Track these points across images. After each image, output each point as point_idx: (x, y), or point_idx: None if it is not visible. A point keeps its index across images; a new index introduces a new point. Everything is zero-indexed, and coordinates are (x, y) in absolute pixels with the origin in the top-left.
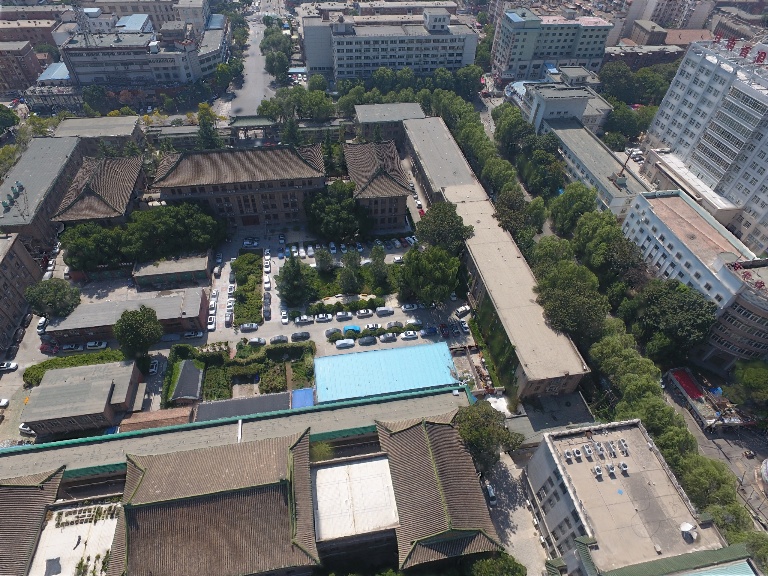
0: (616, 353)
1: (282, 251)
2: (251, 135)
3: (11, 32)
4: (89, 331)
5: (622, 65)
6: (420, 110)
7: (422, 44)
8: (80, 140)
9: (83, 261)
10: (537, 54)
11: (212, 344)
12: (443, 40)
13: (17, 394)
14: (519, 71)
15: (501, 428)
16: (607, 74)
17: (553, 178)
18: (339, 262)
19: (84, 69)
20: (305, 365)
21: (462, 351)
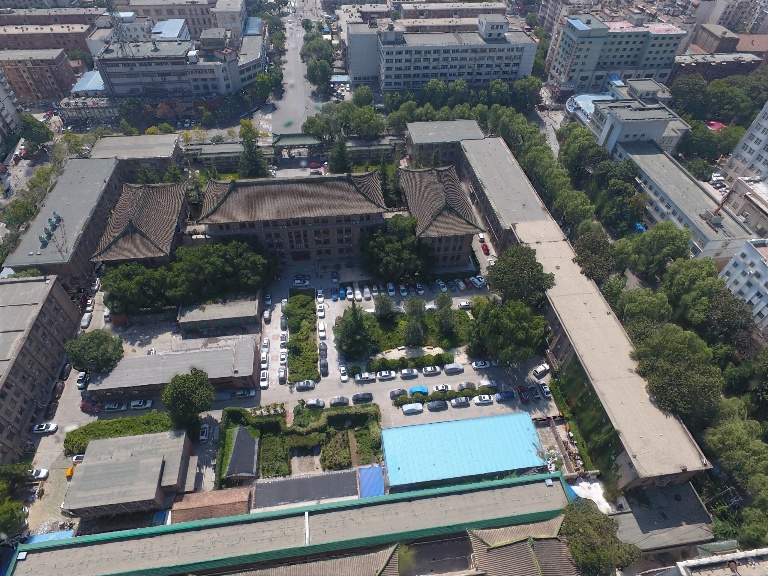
0: (742, 445)
1: (336, 292)
2: (295, 153)
3: (44, 38)
4: (133, 389)
5: (699, 79)
6: (478, 129)
7: (477, 54)
8: (118, 162)
9: (125, 305)
10: (599, 64)
11: (267, 407)
12: (500, 49)
13: (57, 462)
14: (580, 82)
15: (621, 548)
16: (681, 88)
17: (632, 211)
18: (399, 306)
19: (120, 80)
20: (371, 436)
21: (545, 421)
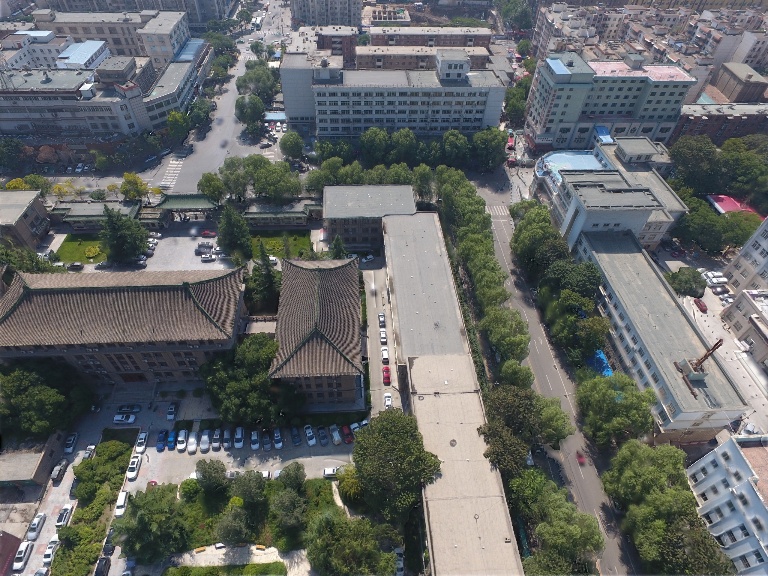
0: None
1: (164, 438)
2: (190, 216)
3: None
4: None
5: (705, 142)
6: (411, 199)
7: (430, 98)
8: None
9: None
10: (586, 112)
11: None
12: (458, 93)
13: None
14: (559, 135)
15: None
16: (682, 153)
17: (587, 338)
18: (241, 468)
19: (4, 115)
20: None
21: None
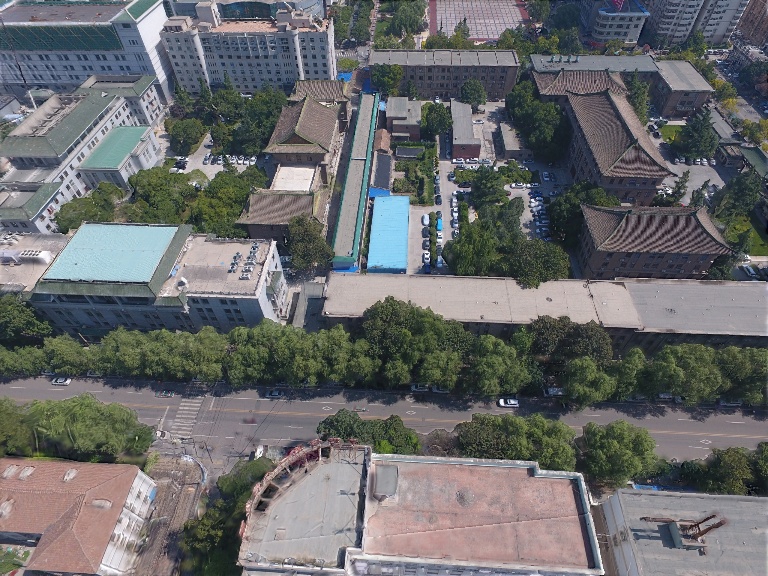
0: None
1: (536, 192)
2: None
3: None
4: None
5: None
6: None
7: None
8: (655, 72)
9: (509, 100)
10: None
11: None
12: None
13: None
14: None
15: (295, 232)
16: None
17: (716, 469)
18: None
19: None
20: None
21: None
